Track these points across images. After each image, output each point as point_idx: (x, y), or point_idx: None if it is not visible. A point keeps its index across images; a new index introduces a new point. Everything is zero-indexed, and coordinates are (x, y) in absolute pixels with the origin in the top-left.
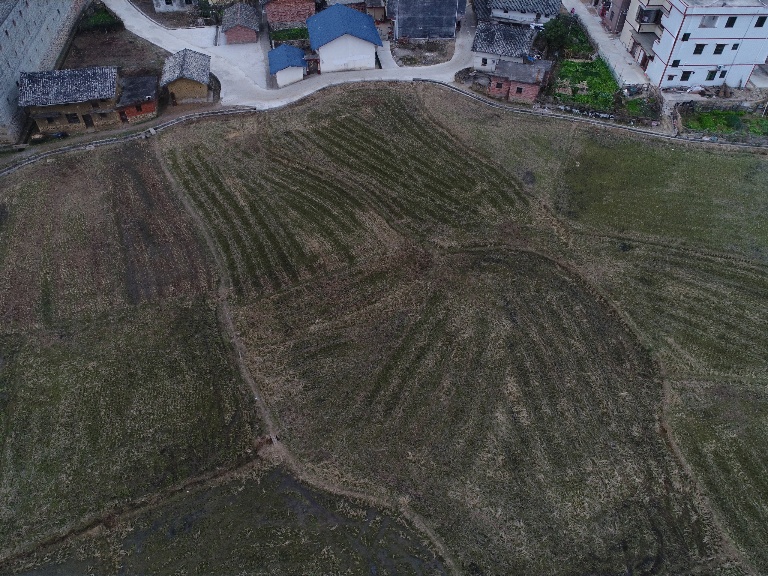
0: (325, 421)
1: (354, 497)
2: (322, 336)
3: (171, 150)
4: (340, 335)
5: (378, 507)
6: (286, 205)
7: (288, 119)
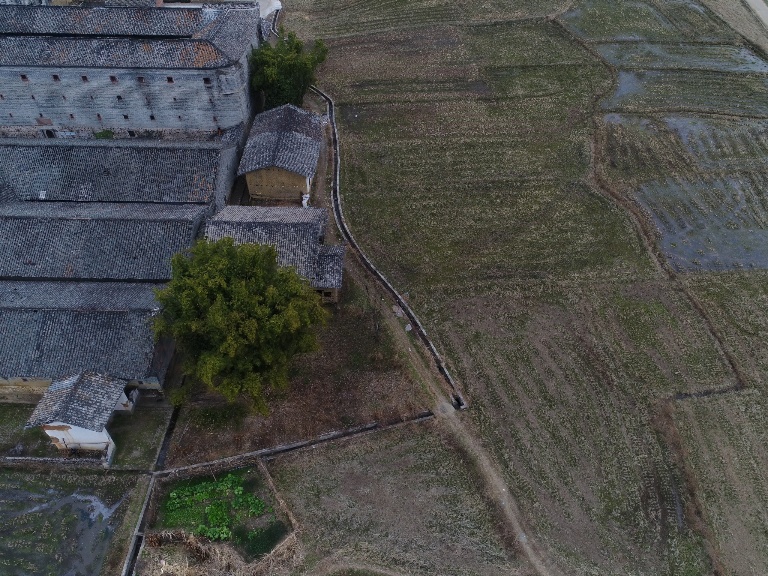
0: (538, 8)
1: (570, 6)
2: (493, 6)
3: (315, 35)
4: (493, 3)
5: (573, 4)
6: (392, 8)
7: (297, 3)
